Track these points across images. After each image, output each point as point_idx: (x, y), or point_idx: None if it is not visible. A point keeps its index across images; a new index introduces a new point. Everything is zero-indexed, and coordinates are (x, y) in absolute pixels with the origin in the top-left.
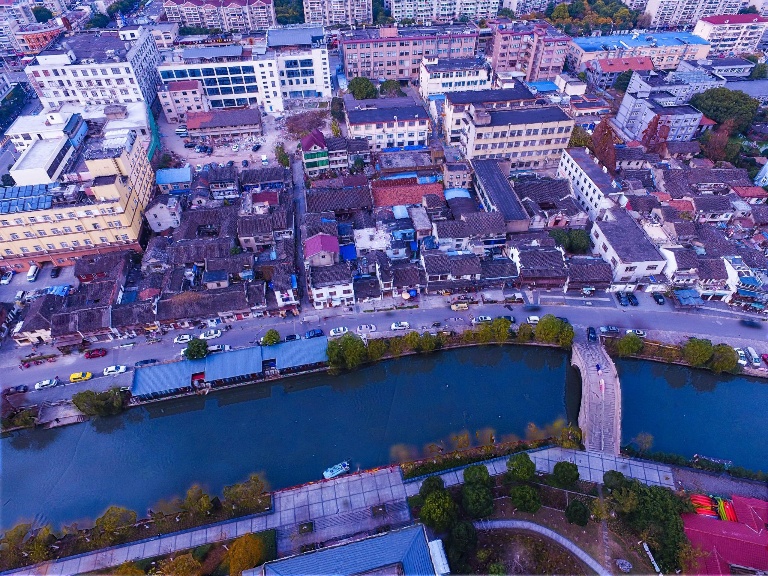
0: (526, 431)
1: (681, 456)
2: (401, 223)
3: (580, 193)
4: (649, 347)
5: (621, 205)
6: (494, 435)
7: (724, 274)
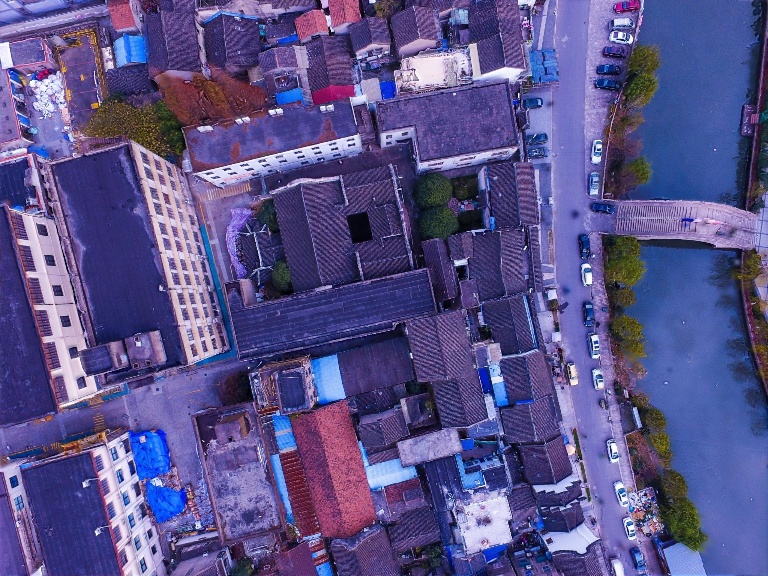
0: (692, 295)
1: (764, 156)
2: (443, 478)
3: (303, 161)
4: (640, 148)
5: (360, 105)
6: (705, 330)
7: (514, 4)
